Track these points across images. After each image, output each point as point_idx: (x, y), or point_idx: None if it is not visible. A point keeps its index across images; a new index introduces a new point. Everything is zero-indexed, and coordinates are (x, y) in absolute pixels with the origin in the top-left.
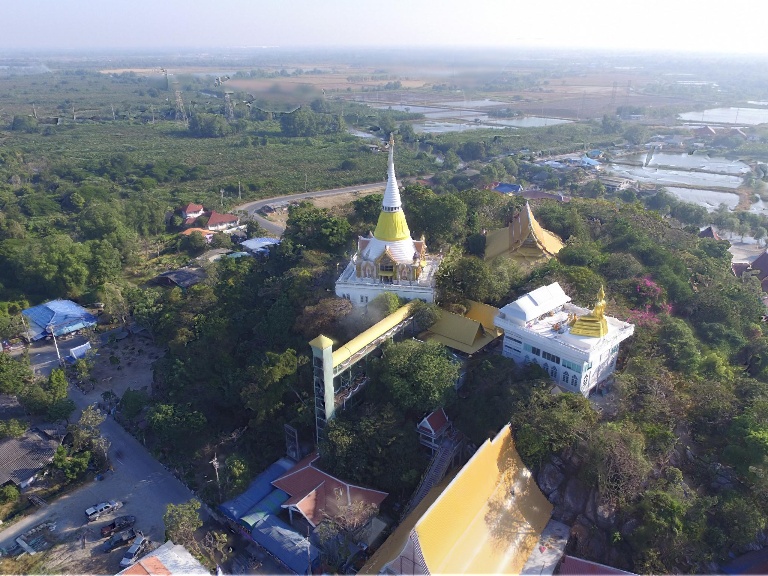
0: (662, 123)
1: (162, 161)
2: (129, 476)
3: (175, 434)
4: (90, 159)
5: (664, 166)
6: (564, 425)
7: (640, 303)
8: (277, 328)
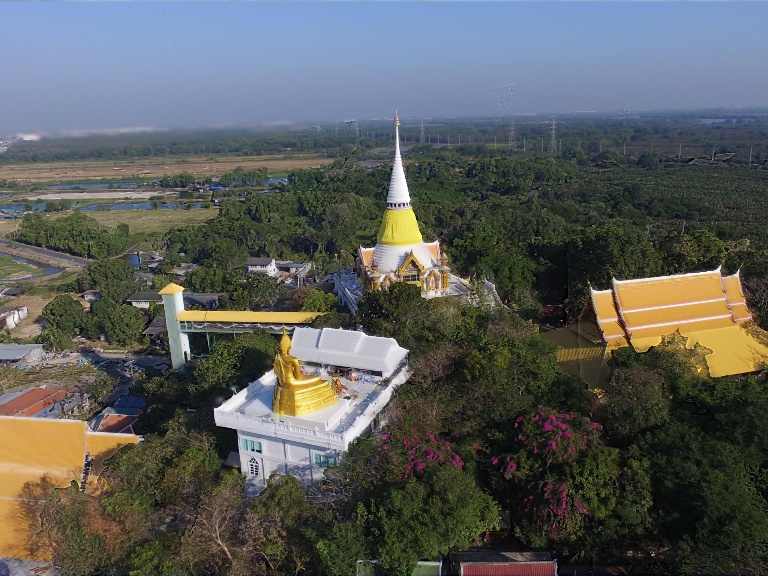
0: None
1: (678, 197)
2: None
3: None
4: None
5: None
6: None
7: (510, 451)
8: None
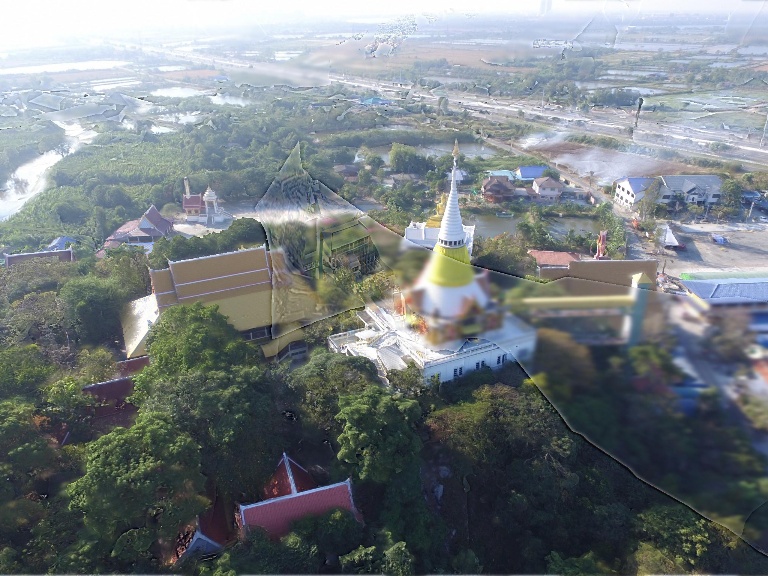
0: None
1: None
2: None
3: None
4: None
5: None
6: (522, 250)
7: None
8: None
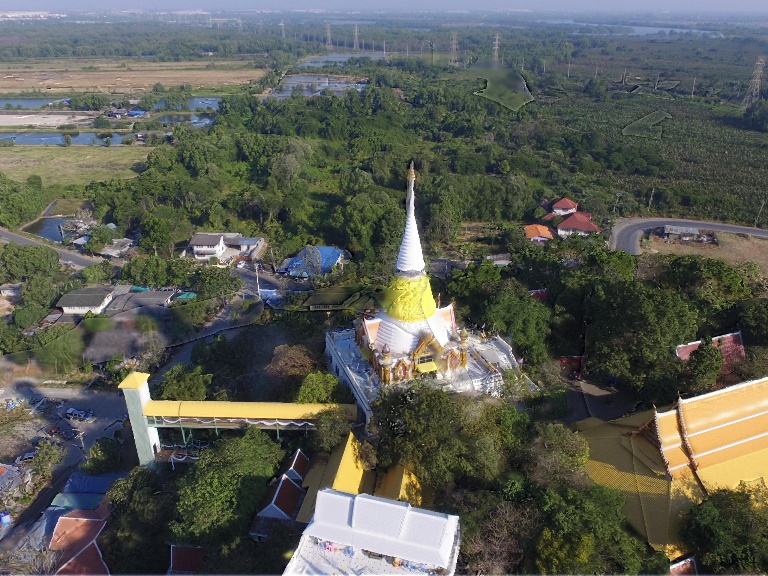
0: None
1: (636, 147)
2: None
3: None
4: (580, 131)
5: None
6: None
7: None
8: None
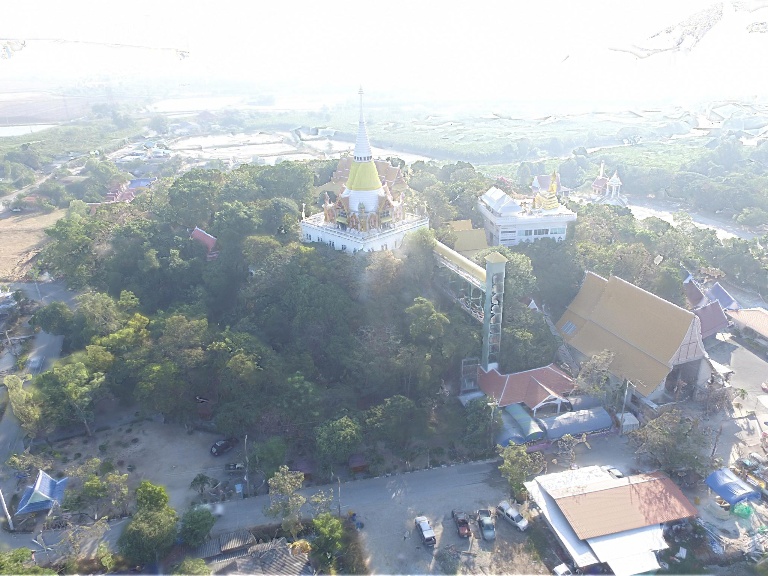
0: (564, 50)
1: None
2: (375, 505)
3: (394, 428)
4: None
5: (220, 145)
6: (611, 256)
7: None
8: (341, 304)
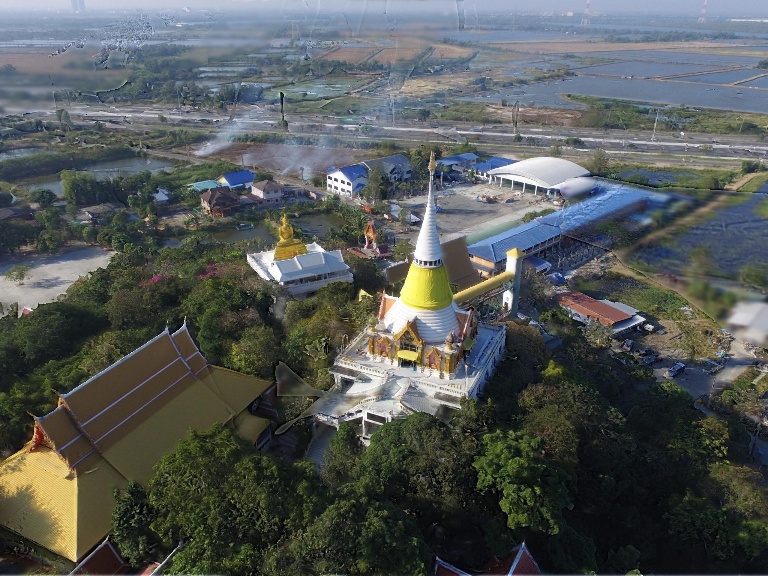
0: None
1: None
2: None
3: None
4: None
5: None
6: None
7: None
8: None
